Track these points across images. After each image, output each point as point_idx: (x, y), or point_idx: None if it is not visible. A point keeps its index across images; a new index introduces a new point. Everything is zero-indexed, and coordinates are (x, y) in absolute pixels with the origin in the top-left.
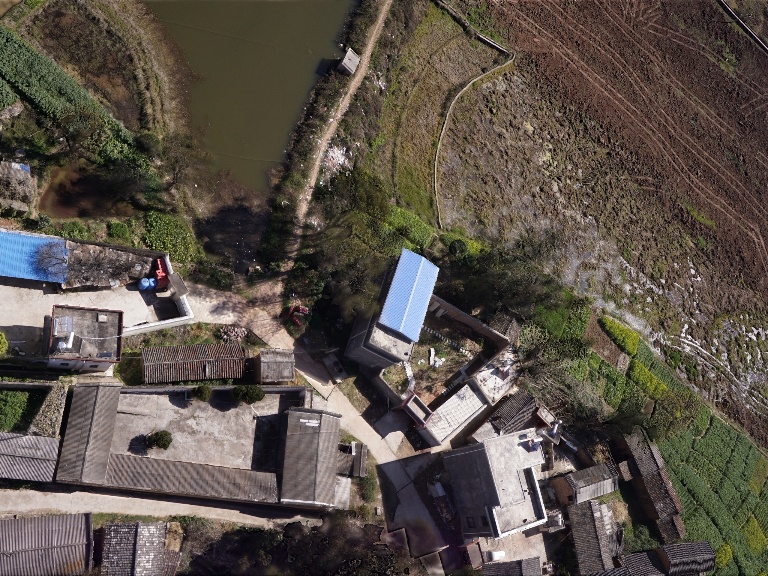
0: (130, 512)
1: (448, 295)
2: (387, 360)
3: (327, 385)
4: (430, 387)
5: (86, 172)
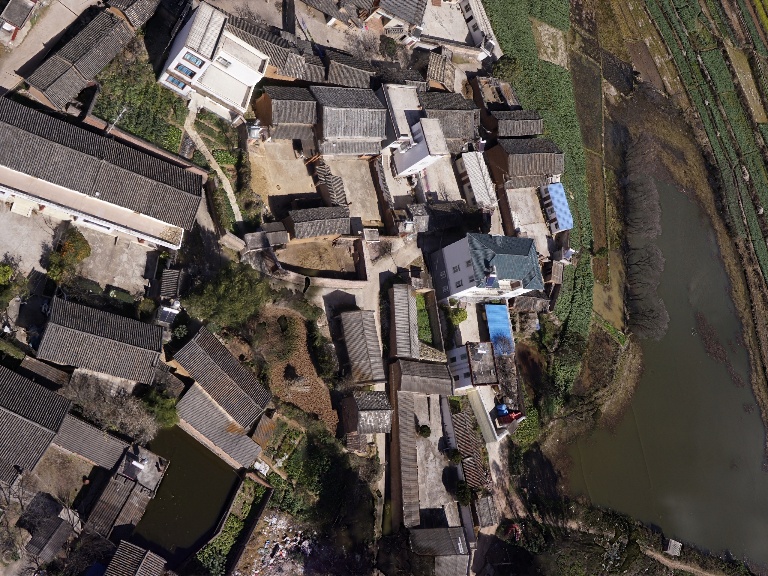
0: None
1: None
2: None
3: (472, 571)
4: None
5: (541, 367)
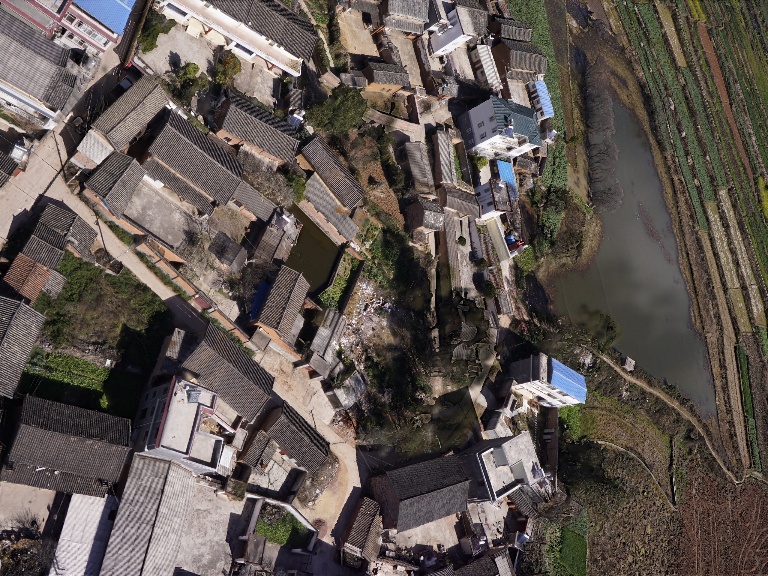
0: None
1: None
2: (531, 373)
3: (495, 350)
4: None
5: (533, 218)
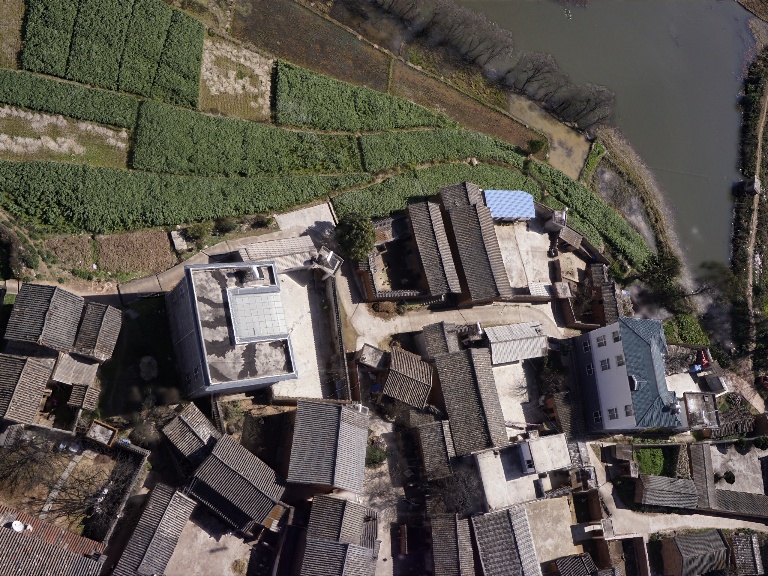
0: (719, 527)
1: None
2: None
3: None
4: None
5: (641, 289)
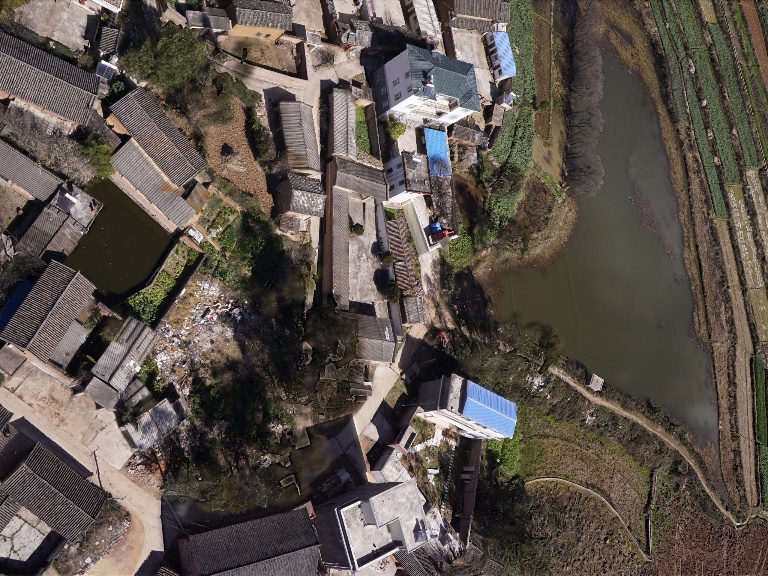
0: None
1: (478, 488)
2: (439, 400)
3: (399, 367)
4: (412, 470)
5: (478, 201)
